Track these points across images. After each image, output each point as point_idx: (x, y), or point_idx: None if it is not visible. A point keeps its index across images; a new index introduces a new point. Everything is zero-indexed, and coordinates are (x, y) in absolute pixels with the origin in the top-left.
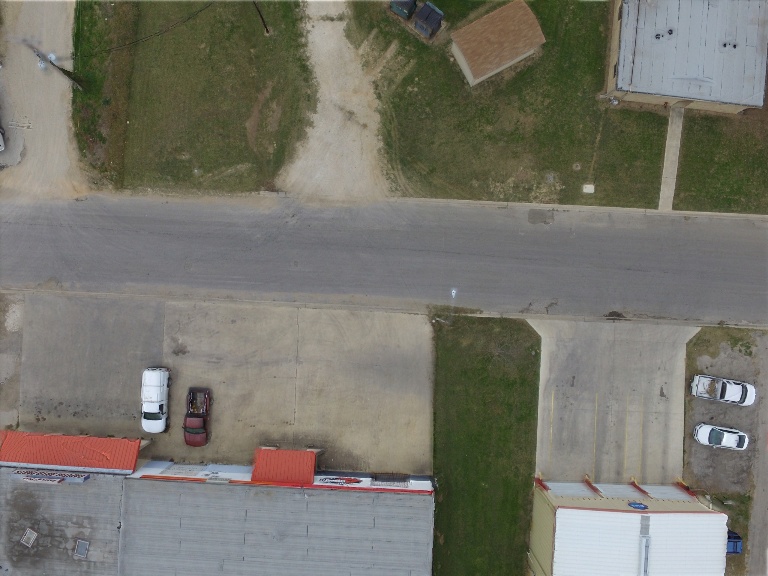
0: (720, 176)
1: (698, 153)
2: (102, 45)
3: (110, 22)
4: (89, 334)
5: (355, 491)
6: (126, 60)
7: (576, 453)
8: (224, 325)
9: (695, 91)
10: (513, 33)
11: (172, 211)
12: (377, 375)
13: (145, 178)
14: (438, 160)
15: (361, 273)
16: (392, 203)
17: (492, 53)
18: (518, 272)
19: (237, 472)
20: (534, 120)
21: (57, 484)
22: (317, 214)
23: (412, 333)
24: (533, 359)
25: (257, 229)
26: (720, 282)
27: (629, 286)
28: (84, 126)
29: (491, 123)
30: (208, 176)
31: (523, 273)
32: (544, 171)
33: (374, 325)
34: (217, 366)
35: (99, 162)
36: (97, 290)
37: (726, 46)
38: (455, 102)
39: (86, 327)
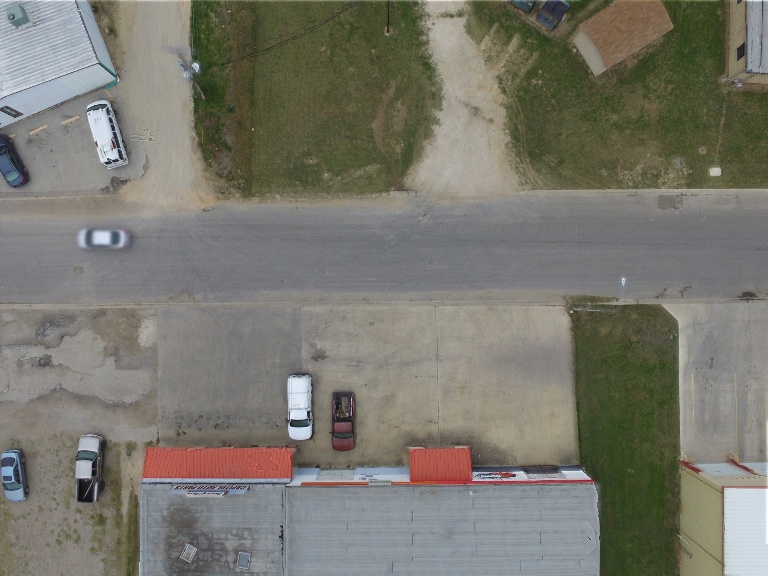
0: None
1: None
2: (221, 53)
3: (228, 29)
4: (226, 345)
5: (518, 485)
6: (247, 67)
7: (719, 434)
8: (362, 328)
9: None
10: (642, 21)
11: (302, 216)
12: (518, 369)
13: (273, 185)
14: (566, 151)
15: (496, 268)
16: (523, 196)
17: (622, 42)
18: (651, 258)
19: (390, 474)
20: (658, 107)
21: (218, 497)
22: (449, 211)
23: (550, 325)
24: (671, 343)
25: (389, 230)
26: None
27: (760, 266)
28: (209, 135)
29: (617, 112)
30: (337, 179)
31: (656, 259)
32: (671, 157)
33: (512, 319)
34: (357, 369)
35: (226, 171)
36: (230, 300)
37: None
38: (580, 93)
39: (222, 338)
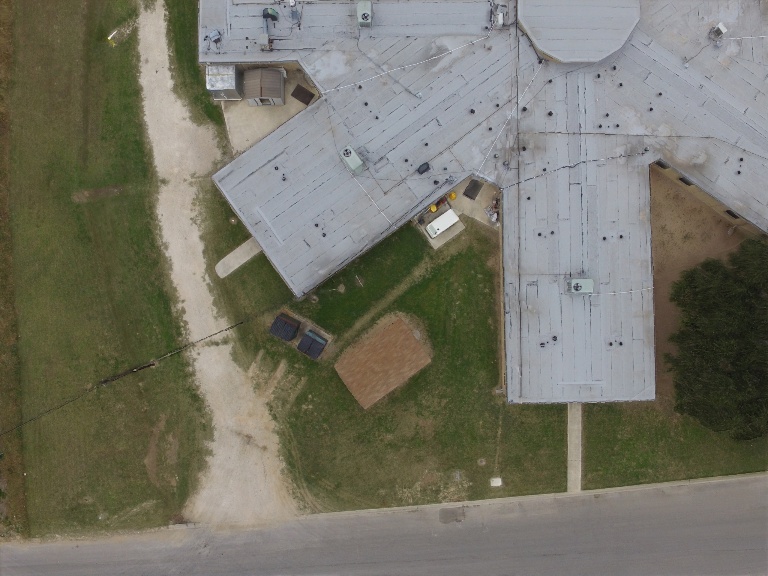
0: (625, 451)
1: (600, 433)
2: None
3: None
4: None
5: None
6: (13, 412)
7: None
8: None
9: (586, 394)
10: (397, 359)
11: (84, 554)
12: None
13: (51, 526)
14: (342, 475)
15: None
16: (302, 521)
17: (378, 382)
18: (435, 573)
19: None
20: (433, 422)
21: None
22: (229, 541)
23: None
24: None
25: (171, 563)
26: (635, 554)
27: (546, 571)
28: None
29: (390, 431)
30: (114, 518)
31: (440, 573)
32: (449, 470)
33: None
34: None
35: (2, 517)
36: None
37: (612, 344)
38: (352, 415)
39: None
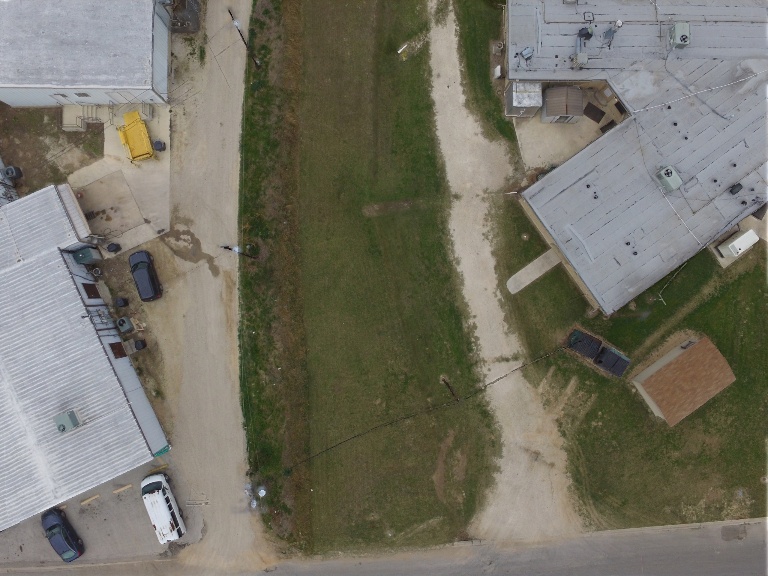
0: None
1: None
2: (275, 413)
3: (279, 388)
4: None
5: None
6: (302, 426)
7: None
8: None
9: None
10: (705, 378)
11: (366, 572)
12: None
13: (335, 543)
14: (630, 492)
15: None
16: (587, 538)
17: (686, 400)
18: None
19: None
20: (719, 440)
21: None
22: (514, 558)
23: None
24: None
25: None
26: None
27: None
28: (267, 499)
29: (678, 448)
30: (400, 535)
31: None
32: (733, 488)
33: None
34: None
35: (286, 533)
36: None
37: None
38: (641, 432)
39: None
